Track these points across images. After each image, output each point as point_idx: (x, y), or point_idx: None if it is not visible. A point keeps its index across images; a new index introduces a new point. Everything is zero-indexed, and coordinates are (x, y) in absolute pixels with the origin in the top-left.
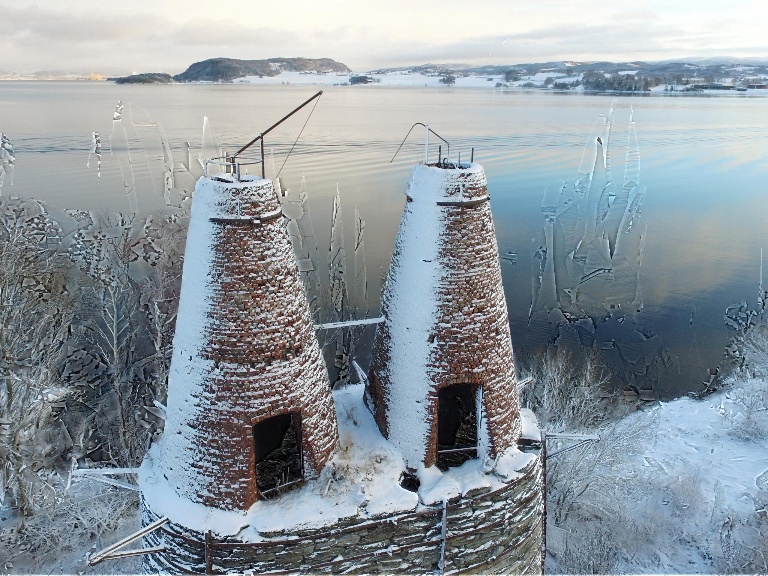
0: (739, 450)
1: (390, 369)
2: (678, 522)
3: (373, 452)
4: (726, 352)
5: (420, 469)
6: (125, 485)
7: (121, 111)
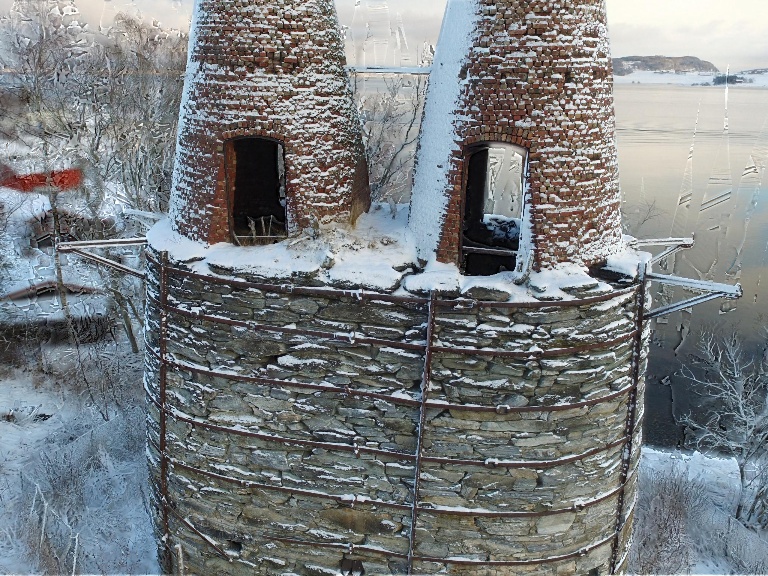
0: None
1: (422, 129)
2: None
3: (385, 234)
4: None
5: (430, 260)
6: None
7: None
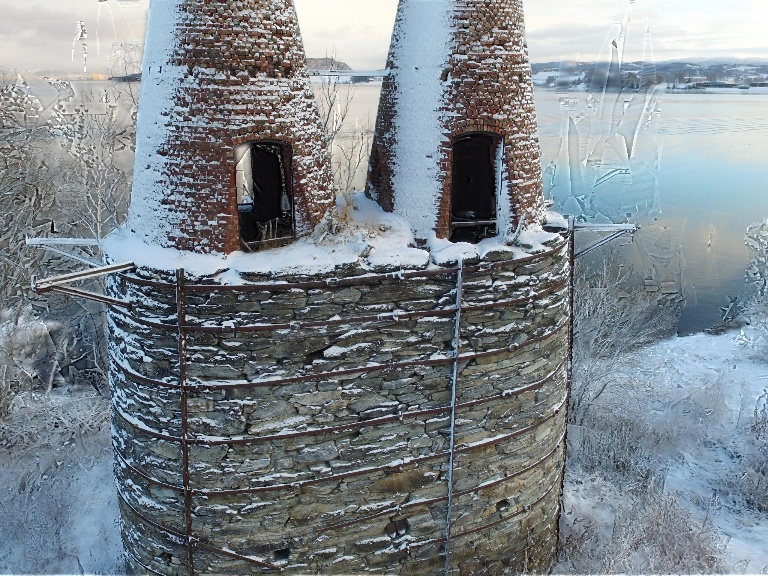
0: (762, 370)
1: (396, 125)
2: (702, 426)
3: (376, 222)
4: (746, 275)
5: (430, 238)
6: (89, 260)
7: None
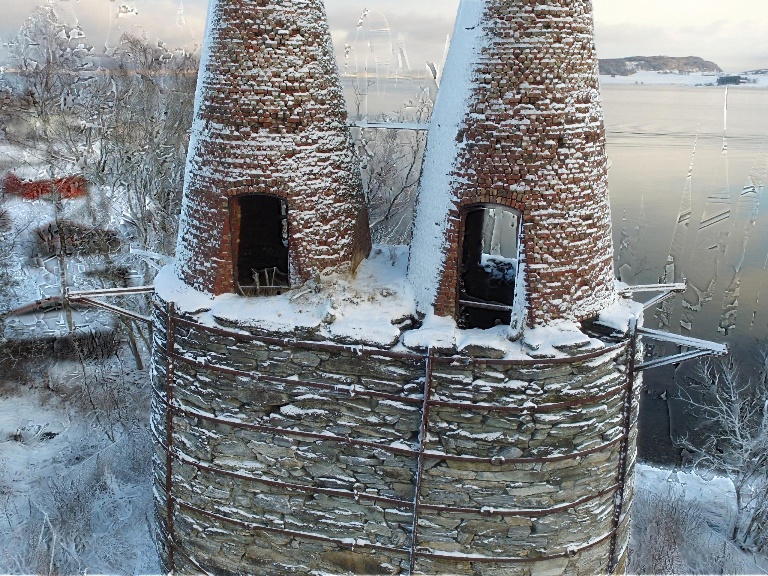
0: None
1: (420, 185)
2: None
3: (384, 285)
4: None
5: (428, 314)
6: None
7: (364, 17)
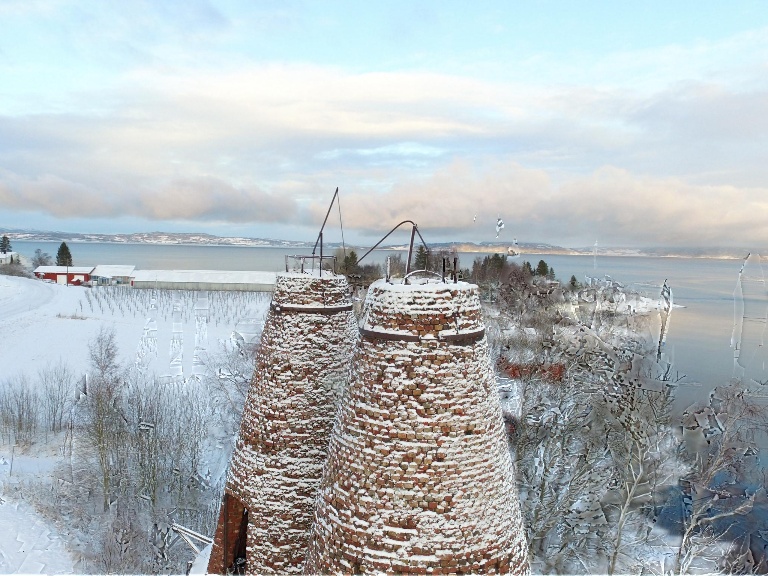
0: None
1: None
2: None
3: None
4: None
5: None
6: None
7: None
